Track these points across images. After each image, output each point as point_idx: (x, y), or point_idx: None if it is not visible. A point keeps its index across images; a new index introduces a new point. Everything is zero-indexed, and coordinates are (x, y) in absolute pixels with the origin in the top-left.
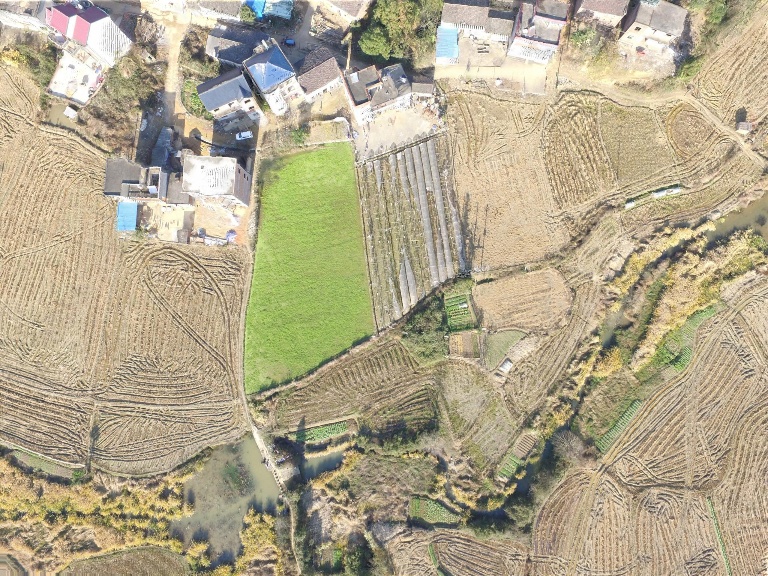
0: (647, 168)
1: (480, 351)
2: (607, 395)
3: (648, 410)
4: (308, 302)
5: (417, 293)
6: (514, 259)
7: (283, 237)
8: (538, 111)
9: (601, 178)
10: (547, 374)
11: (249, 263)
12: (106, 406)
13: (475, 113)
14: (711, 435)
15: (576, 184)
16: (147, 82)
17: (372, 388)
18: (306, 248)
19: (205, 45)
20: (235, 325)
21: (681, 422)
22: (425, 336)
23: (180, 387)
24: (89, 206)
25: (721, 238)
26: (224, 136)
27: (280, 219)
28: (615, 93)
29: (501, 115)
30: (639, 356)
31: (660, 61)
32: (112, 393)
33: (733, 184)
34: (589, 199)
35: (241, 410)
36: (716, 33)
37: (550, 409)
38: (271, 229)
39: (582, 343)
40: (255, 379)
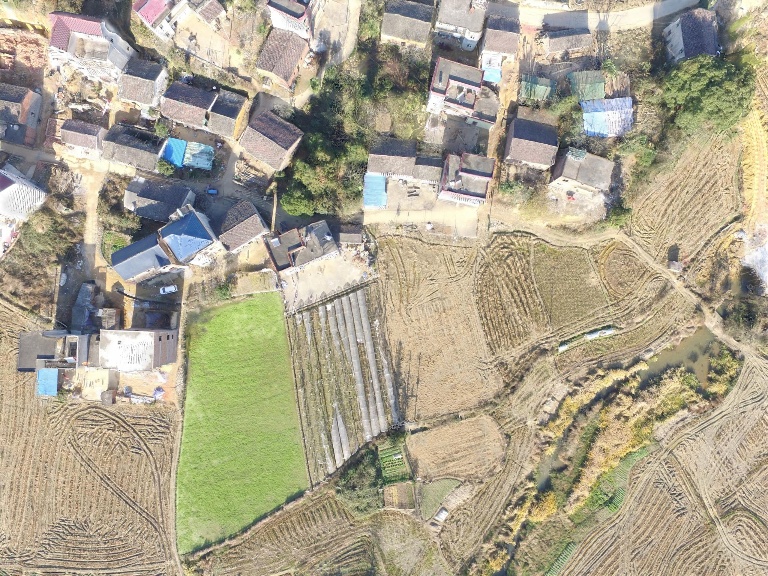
0: (580, 310)
1: (415, 502)
2: (542, 539)
3: (583, 552)
4: (240, 458)
5: (350, 447)
6: (448, 407)
7: (212, 392)
8: (470, 254)
9: (534, 321)
10: (483, 520)
11: (178, 421)
12: (35, 572)
13: (406, 258)
14: (644, 574)
15: (509, 329)
16: (64, 236)
17: (307, 542)
18: (236, 403)
19: (123, 199)
20: (166, 485)
21: (615, 563)
22: (359, 492)
23: (111, 550)
24: (9, 366)
25: (654, 376)
26: (148, 289)
27: (209, 374)
28: (547, 234)
29: (433, 259)
30: (573, 499)
31: (591, 205)
32: (41, 559)
33: (666, 322)
34: (522, 343)
35: (174, 571)
36: (647, 173)
37: (486, 555)
38: (200, 384)
39: (517, 488)
40: (188, 539)
